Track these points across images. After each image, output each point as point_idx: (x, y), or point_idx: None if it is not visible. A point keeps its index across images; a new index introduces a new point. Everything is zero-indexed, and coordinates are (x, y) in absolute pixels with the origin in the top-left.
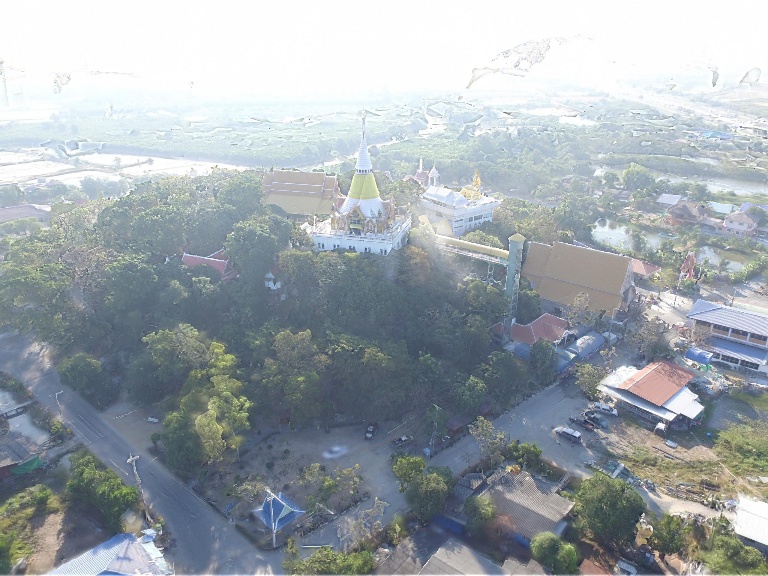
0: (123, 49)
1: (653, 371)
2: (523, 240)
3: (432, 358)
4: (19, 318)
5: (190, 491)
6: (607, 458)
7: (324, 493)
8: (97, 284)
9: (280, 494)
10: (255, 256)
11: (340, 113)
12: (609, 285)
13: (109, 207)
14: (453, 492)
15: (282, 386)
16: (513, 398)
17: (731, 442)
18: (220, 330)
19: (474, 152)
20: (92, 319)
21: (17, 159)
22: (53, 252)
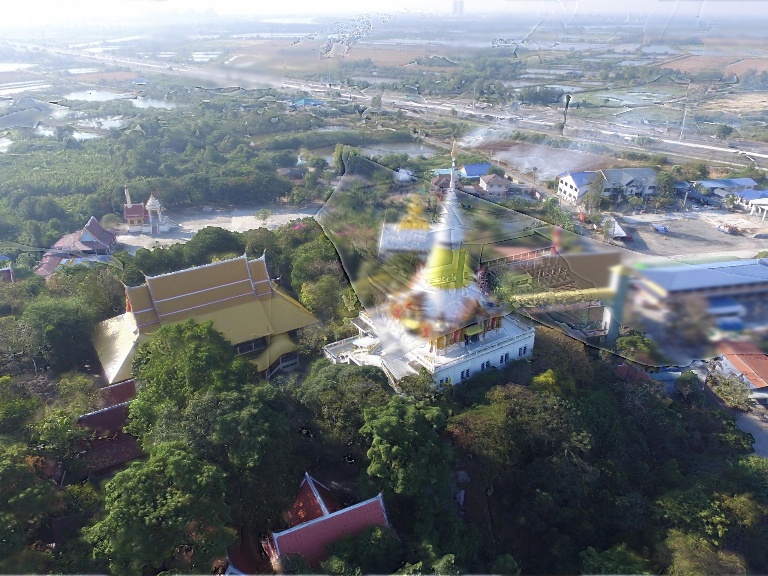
0: None
1: (739, 356)
2: None
3: None
4: None
5: None
6: None
7: None
8: None
9: None
10: None
11: None
12: None
13: None
14: None
15: None
16: None
17: None
18: None
19: (139, 163)
20: None
21: None
22: None
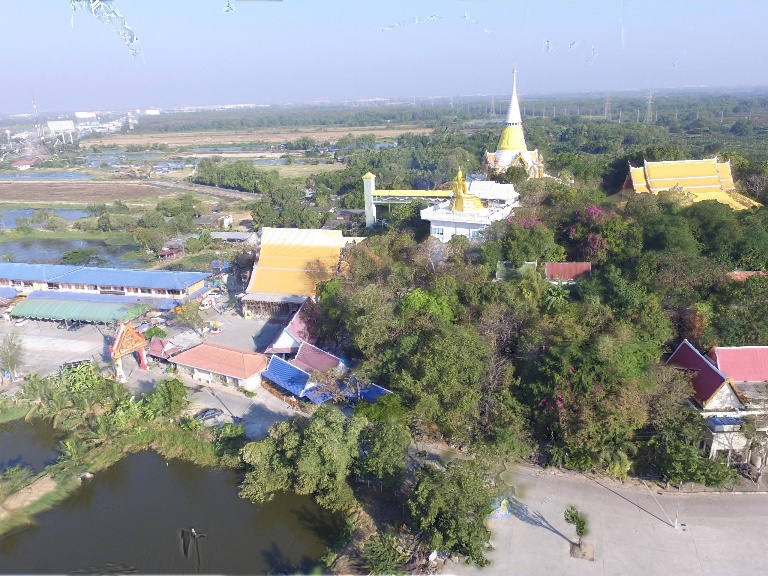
0: None
1: None
2: None
3: None
4: None
5: None
6: None
7: None
8: None
9: None
10: None
11: None
12: None
13: None
14: None
15: None
16: None
17: (232, 256)
18: None
19: None
20: None
21: None
22: None
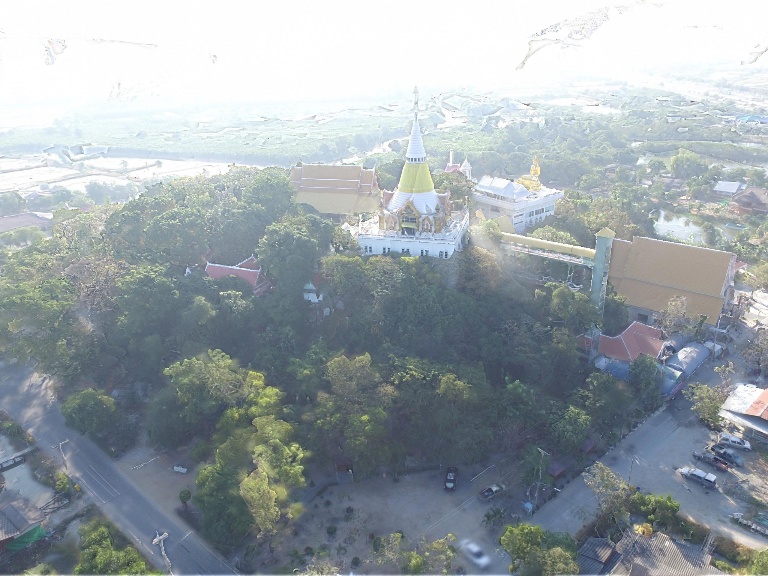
0: (129, 30)
1: None
2: (613, 236)
3: (522, 385)
4: (16, 345)
5: (233, 570)
6: (755, 509)
7: (411, 575)
8: (107, 302)
9: (351, 575)
10: (293, 264)
11: (352, 110)
12: (706, 286)
13: (118, 211)
14: (579, 568)
15: (341, 428)
16: (615, 429)
17: None
18: (256, 355)
19: (503, 143)
20: (102, 344)
21: (18, 165)
22: (55, 265)
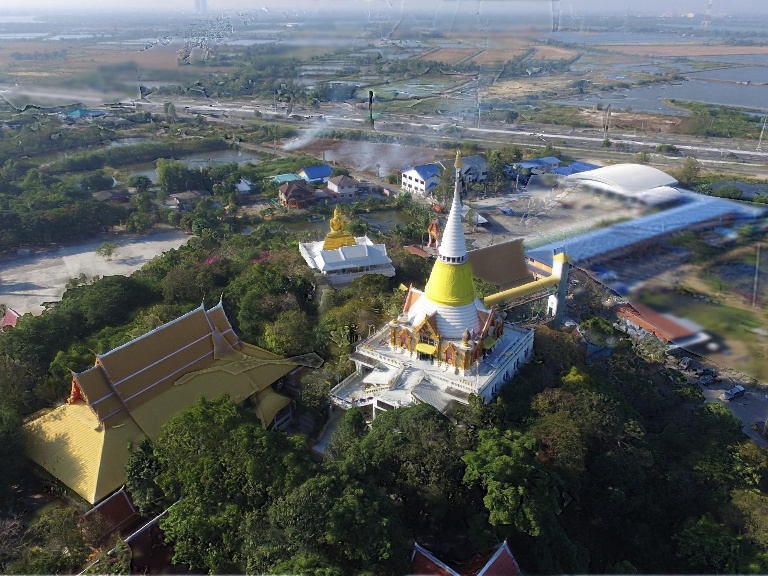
0: None
1: (638, 316)
2: None
3: None
4: None
5: None
6: None
7: None
8: None
9: None
10: None
11: None
12: (519, 272)
13: None
14: None
15: None
16: None
17: None
18: None
19: None
20: None
21: None
22: None
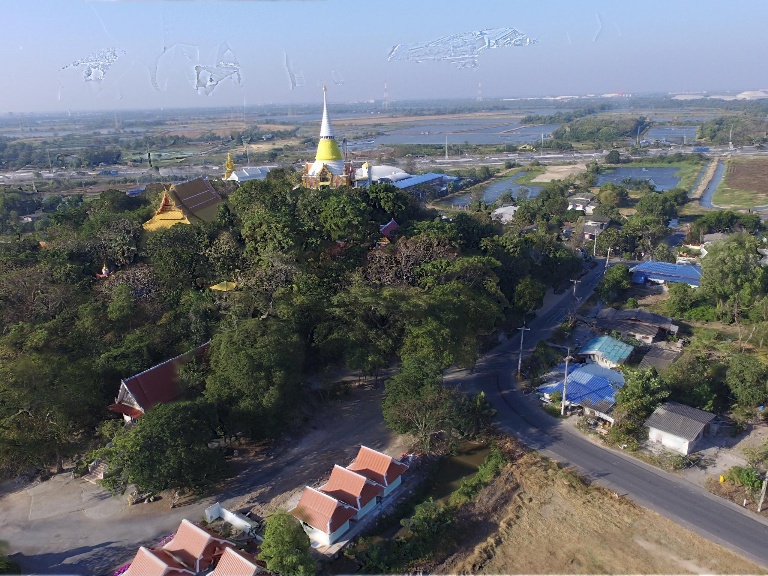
0: (119, 2)
1: None
2: None
3: None
4: None
5: None
6: None
7: None
8: None
9: None
10: None
11: None
12: None
13: None
14: None
15: None
16: None
17: None
18: None
19: None
20: None
21: None
22: None
